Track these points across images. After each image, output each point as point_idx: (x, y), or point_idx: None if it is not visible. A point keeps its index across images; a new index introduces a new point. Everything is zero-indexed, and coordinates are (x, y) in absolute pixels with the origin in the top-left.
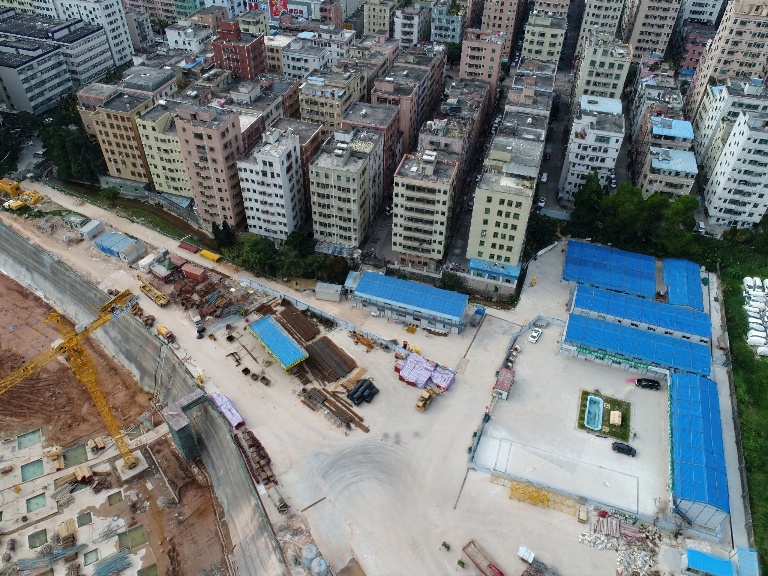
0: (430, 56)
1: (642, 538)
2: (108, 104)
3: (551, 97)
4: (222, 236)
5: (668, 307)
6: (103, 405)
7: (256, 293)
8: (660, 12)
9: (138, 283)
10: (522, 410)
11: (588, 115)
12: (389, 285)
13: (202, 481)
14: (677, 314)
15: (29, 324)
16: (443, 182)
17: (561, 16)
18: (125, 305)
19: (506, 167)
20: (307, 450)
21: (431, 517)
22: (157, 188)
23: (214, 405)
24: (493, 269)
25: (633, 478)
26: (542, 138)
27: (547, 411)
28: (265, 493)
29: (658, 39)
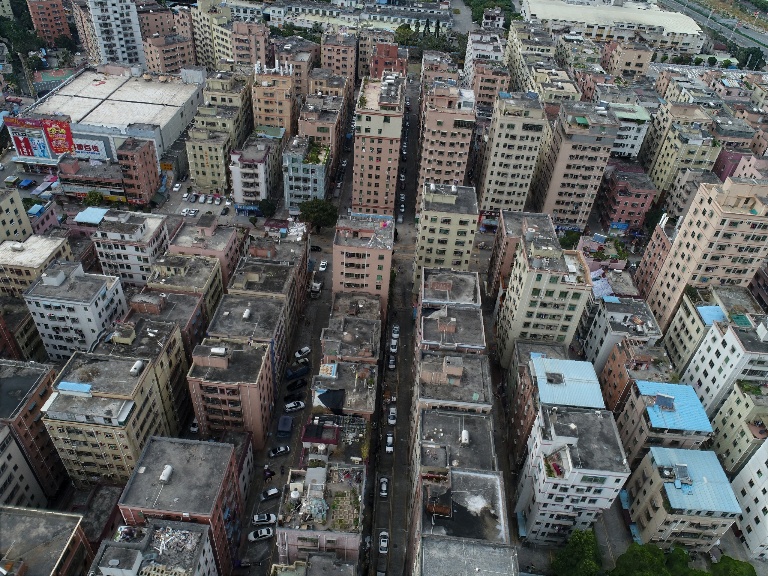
0: (285, 264)
1: None
2: None
3: (486, 365)
4: None
5: None
6: None
7: None
8: (585, 162)
9: None
10: None
11: (563, 435)
12: None
13: None
14: None
15: None
16: None
17: (459, 166)
18: None
19: None
20: None
21: None
22: None
23: None
24: None
25: None
26: (500, 504)
27: None
28: None
29: (584, 192)
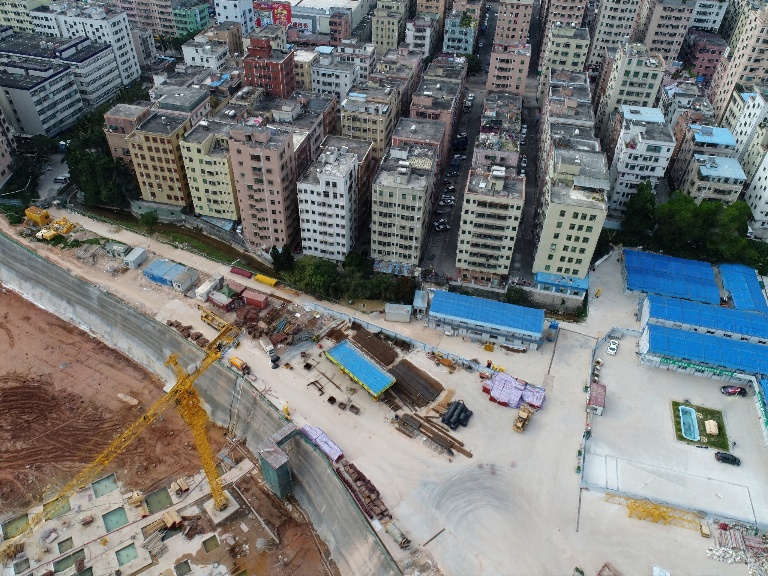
0: (457, 69)
1: (767, 549)
2: (145, 126)
3: (591, 108)
4: (282, 260)
5: (740, 313)
6: (206, 447)
7: (322, 317)
8: (672, 21)
9: (197, 312)
10: (619, 425)
11: (638, 125)
12: (463, 303)
13: (299, 519)
14: (751, 320)
15: (80, 361)
16: (515, 197)
17: None
18: (232, 341)
19: (577, 180)
20: (414, 480)
21: (556, 542)
22: (197, 211)
23: (307, 438)
24: (562, 282)
25: (743, 488)
26: (597, 149)
27: (643, 424)
28: (381, 529)
29: (670, 47)
